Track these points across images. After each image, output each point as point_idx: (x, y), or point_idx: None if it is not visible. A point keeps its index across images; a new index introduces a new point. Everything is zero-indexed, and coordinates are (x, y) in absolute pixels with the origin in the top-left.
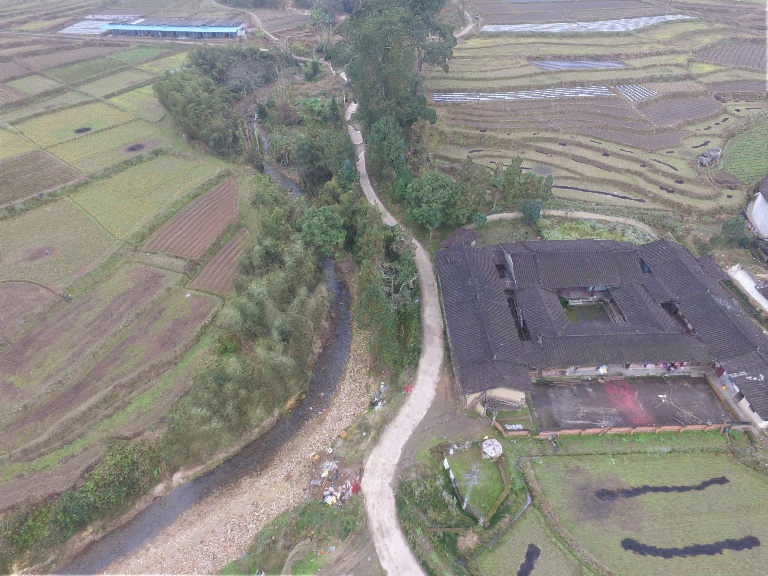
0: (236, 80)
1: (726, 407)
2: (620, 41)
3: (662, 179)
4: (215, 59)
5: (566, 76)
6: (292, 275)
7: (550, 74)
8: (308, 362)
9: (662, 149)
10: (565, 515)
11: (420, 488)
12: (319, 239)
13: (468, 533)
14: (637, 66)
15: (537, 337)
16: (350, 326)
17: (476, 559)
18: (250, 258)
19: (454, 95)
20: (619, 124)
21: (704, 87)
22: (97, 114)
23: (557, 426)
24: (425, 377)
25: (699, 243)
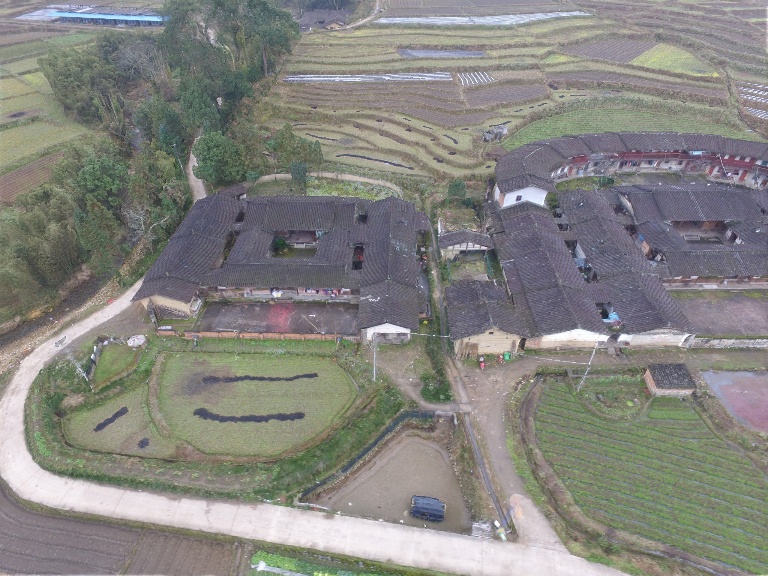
0: (124, 60)
1: None
2: (496, 34)
3: (439, 151)
4: (120, 42)
5: (420, 63)
6: (53, 210)
7: (407, 61)
8: (68, 285)
9: (460, 126)
10: (167, 391)
11: (62, 364)
12: (90, 183)
13: (76, 395)
14: (493, 56)
15: None
16: (124, 261)
17: (73, 413)
18: (27, 196)
19: (305, 76)
20: (436, 105)
21: (543, 75)
22: (3, 87)
23: None
24: (131, 293)
25: (432, 203)
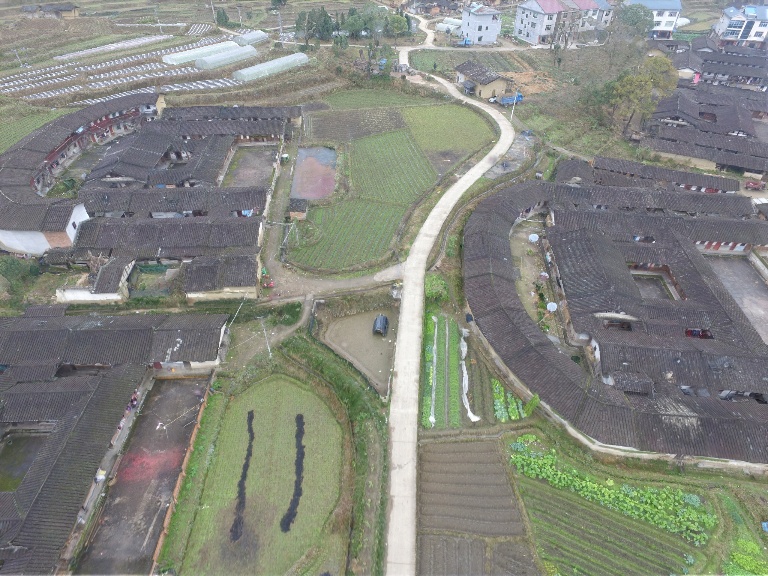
0: None
1: (191, 378)
2: None
3: None
4: None
5: None
6: None
7: None
8: None
9: None
10: None
11: None
12: None
13: None
14: None
15: (6, 551)
16: None
17: None
18: None
19: None
20: None
21: None
22: None
23: (145, 561)
24: None
25: (4, 303)
